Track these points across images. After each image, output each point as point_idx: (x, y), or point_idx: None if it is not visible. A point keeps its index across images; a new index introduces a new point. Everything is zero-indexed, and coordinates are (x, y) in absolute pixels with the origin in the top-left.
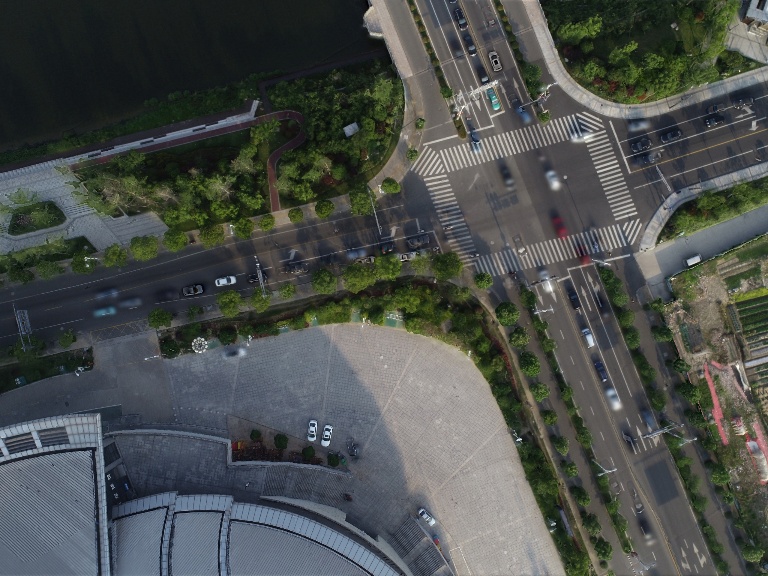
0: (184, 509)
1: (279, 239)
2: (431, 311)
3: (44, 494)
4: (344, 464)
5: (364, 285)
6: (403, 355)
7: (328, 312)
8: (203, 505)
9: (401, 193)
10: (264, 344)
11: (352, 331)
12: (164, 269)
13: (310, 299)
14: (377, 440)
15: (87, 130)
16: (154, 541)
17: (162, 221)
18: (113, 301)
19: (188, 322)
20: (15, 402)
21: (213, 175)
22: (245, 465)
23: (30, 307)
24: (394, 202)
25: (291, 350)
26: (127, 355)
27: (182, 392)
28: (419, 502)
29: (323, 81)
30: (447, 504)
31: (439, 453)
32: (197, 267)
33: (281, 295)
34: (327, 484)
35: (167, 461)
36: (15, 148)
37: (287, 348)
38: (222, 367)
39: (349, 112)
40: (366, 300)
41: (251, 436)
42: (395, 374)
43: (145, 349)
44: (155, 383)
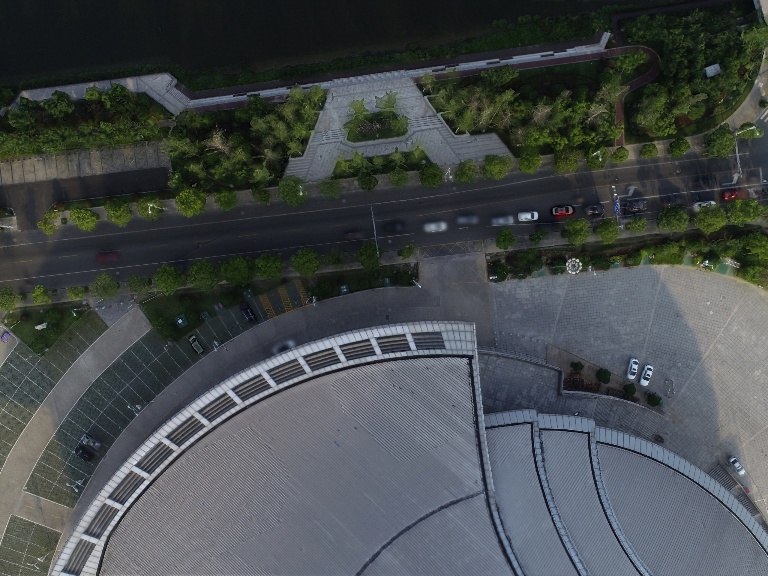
0: (549, 427)
1: (619, 174)
2: (767, 262)
3: (419, 396)
4: (662, 405)
5: (719, 226)
6: (730, 303)
7: (668, 251)
8: (567, 425)
9: (748, 141)
10: (592, 278)
11: (682, 274)
12: (500, 192)
13: (645, 237)
14: (694, 385)
15: (433, 44)
16: (526, 454)
17: (503, 143)
18: (445, 219)
19: (518, 248)
20: (335, 310)
21: (581, 100)
22: (579, 394)
23: (360, 216)
24: (740, 149)
25: (618, 286)
26: (453, 274)
27: (504, 317)
28: (729, 451)
29: (686, 19)
30: (757, 455)
31: (755, 404)
32: (533, 194)
33: (632, 228)
34: (644, 423)
35: (499, 382)
36: (356, 55)
37: (615, 284)
38: (547, 296)
39: (713, 52)
40: (705, 244)
41: (576, 367)
42: (720, 321)
43: (472, 270)
44: (478, 305)
